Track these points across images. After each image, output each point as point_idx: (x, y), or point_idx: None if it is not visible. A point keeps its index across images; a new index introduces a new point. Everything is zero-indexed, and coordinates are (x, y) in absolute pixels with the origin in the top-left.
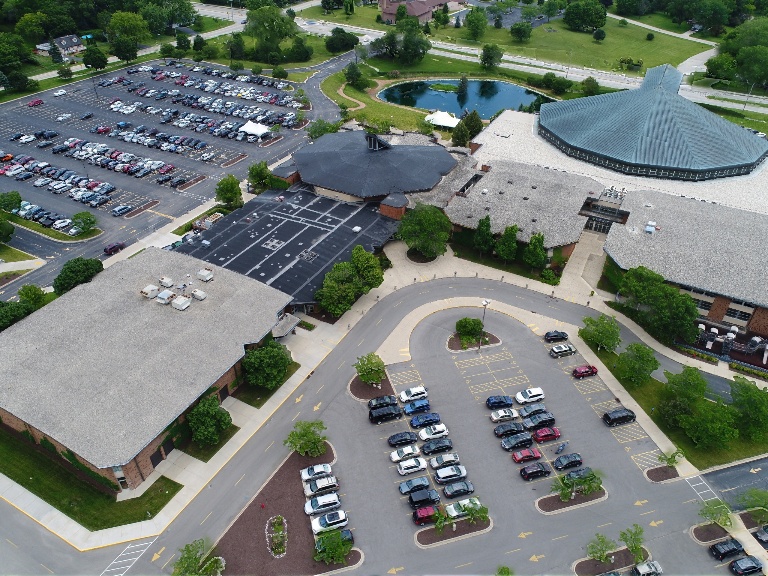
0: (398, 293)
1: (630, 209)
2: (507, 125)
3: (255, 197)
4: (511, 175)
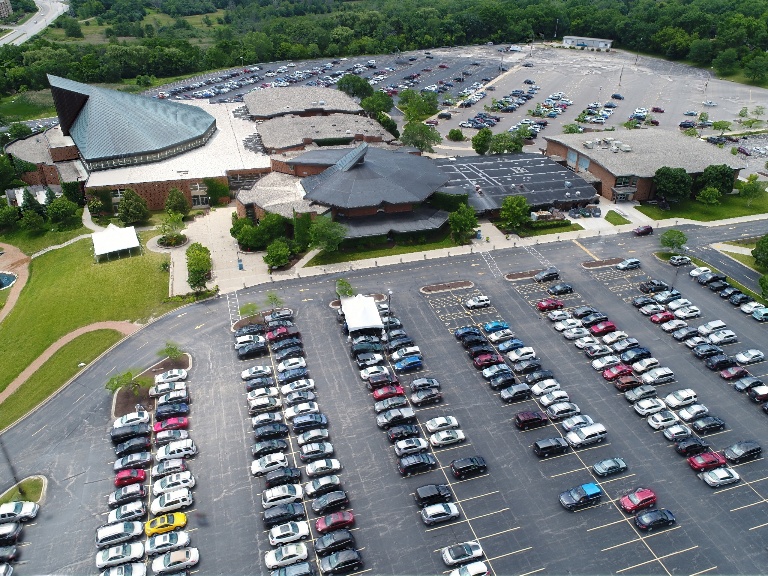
0: (463, 156)
1: (300, 109)
2: (148, 176)
3: (492, 208)
4: (304, 134)
